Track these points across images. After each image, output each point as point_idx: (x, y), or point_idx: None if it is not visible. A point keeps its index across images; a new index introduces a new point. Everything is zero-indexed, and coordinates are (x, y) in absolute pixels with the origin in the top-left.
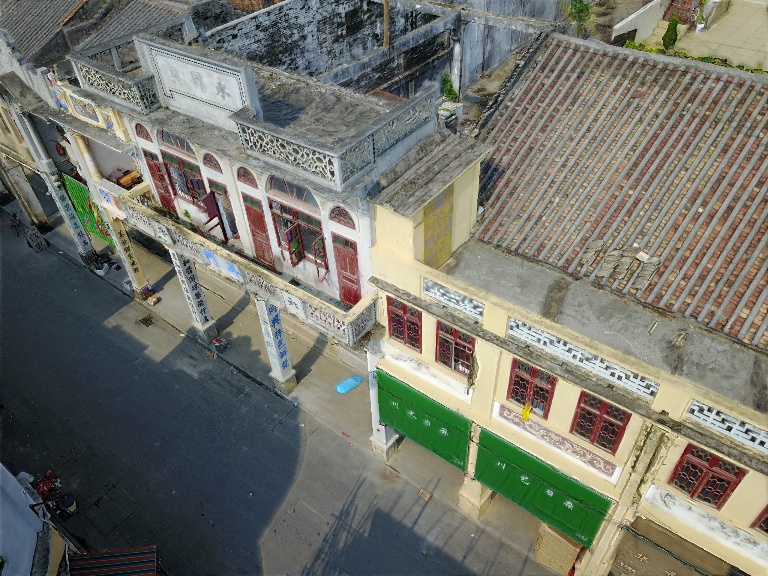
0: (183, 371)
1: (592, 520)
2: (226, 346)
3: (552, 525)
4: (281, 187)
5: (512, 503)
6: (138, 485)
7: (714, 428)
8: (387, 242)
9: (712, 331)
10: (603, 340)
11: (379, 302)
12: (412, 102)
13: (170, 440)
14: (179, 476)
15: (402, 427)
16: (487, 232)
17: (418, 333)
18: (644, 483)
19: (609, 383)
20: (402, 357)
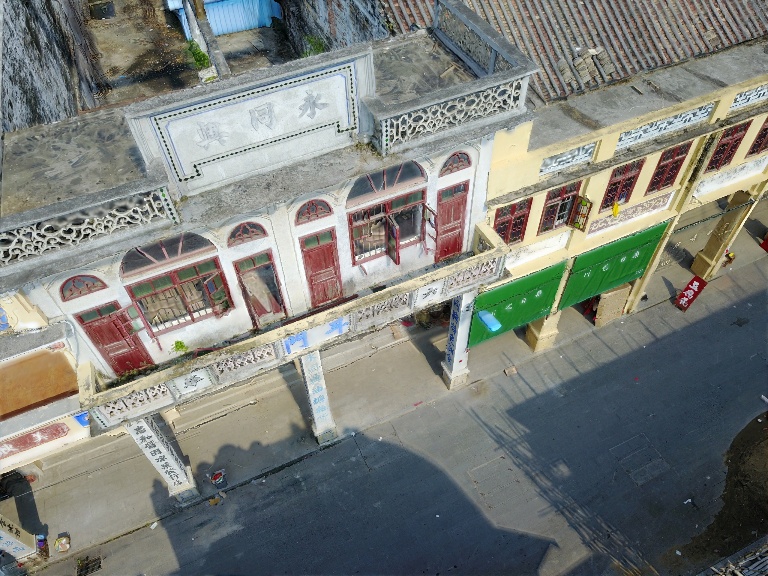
0: (218, 541)
1: (651, 250)
2: None
3: None
4: (362, 189)
5: None
6: None
7: (740, 107)
8: (498, 156)
9: (653, 71)
10: (637, 115)
11: None
12: (467, 8)
13: None
14: None
15: None
16: None
17: (523, 223)
18: None
19: (683, 129)
20: None
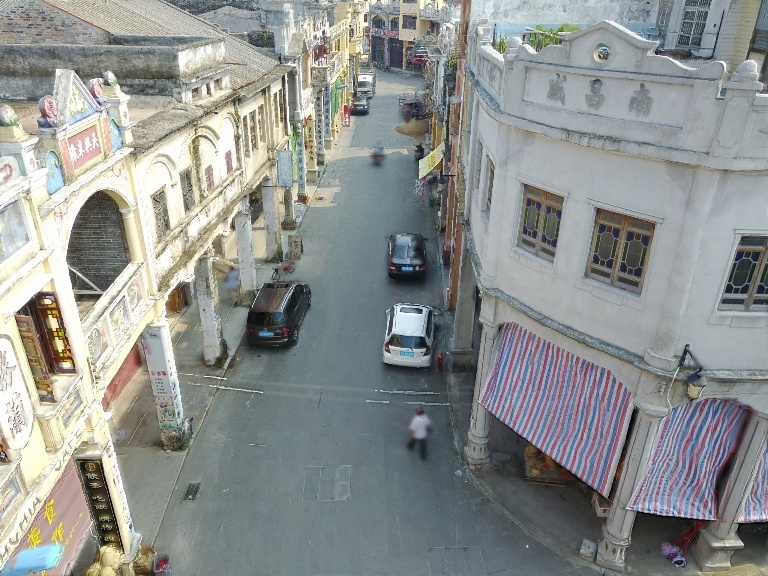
0: None
1: None
2: None
3: None
4: None
5: None
6: None
7: None
8: None
9: None
10: None
11: None
12: None
13: None
14: None
15: None
16: None
17: None
18: None
19: (335, 35)
20: None
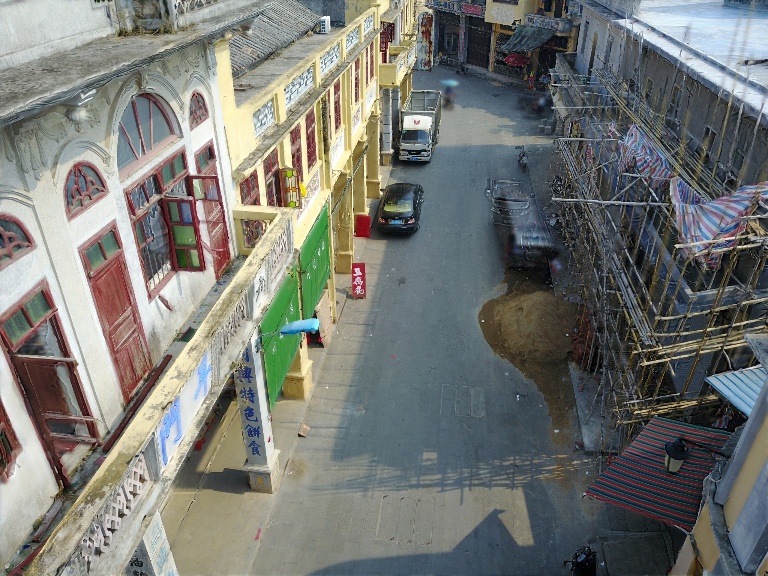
0: None
1: None
2: None
3: None
4: (123, 152)
5: None
6: None
7: None
8: None
9: None
10: None
11: None
12: None
13: None
14: None
15: None
16: None
17: None
18: None
19: (308, 93)
20: None
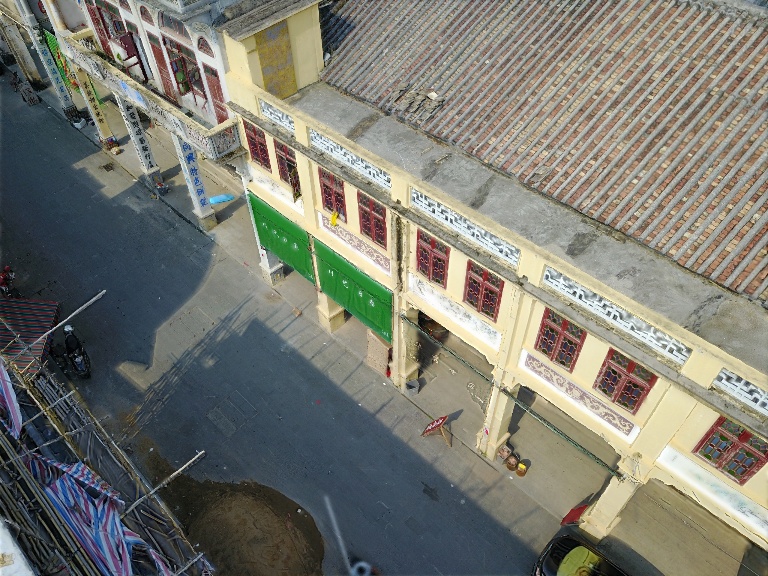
0: (129, 207)
1: (386, 314)
2: (167, 190)
3: (369, 326)
4: (169, 24)
5: (363, 324)
6: (73, 283)
7: (427, 212)
8: (236, 69)
9: (470, 156)
10: (383, 155)
11: (240, 127)
12: None
13: (106, 255)
14: (106, 280)
15: (273, 248)
16: (329, 74)
17: (266, 153)
18: (402, 271)
19: (369, 180)
20: (263, 179)
